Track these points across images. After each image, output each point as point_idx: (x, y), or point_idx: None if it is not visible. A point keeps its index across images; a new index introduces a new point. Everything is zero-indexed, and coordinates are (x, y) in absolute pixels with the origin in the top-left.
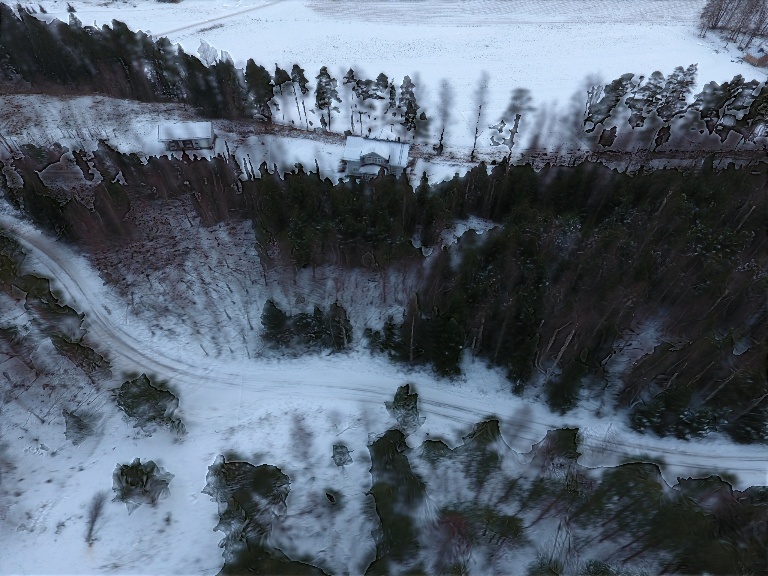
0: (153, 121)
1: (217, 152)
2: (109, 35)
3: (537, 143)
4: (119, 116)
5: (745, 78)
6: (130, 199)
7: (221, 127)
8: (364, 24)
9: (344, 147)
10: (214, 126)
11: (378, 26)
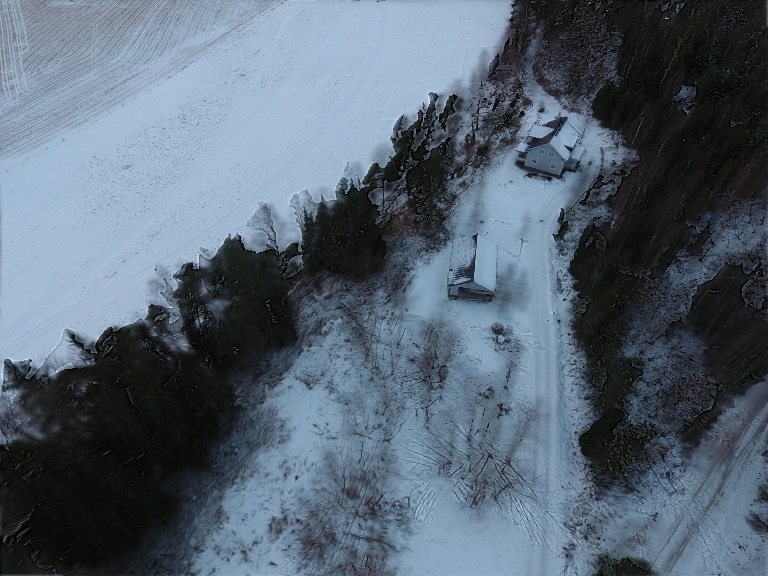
0: (391, 317)
1: (501, 256)
2: (257, 275)
3: (463, 98)
4: (369, 355)
5: (410, 6)
6: (620, 330)
7: (422, 255)
8: (81, 131)
9: (494, 173)
10: (420, 259)
11: (101, 123)
